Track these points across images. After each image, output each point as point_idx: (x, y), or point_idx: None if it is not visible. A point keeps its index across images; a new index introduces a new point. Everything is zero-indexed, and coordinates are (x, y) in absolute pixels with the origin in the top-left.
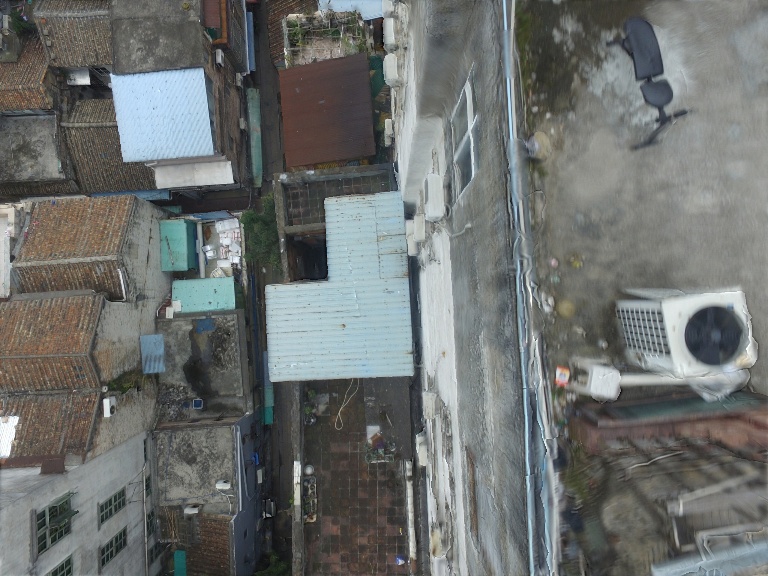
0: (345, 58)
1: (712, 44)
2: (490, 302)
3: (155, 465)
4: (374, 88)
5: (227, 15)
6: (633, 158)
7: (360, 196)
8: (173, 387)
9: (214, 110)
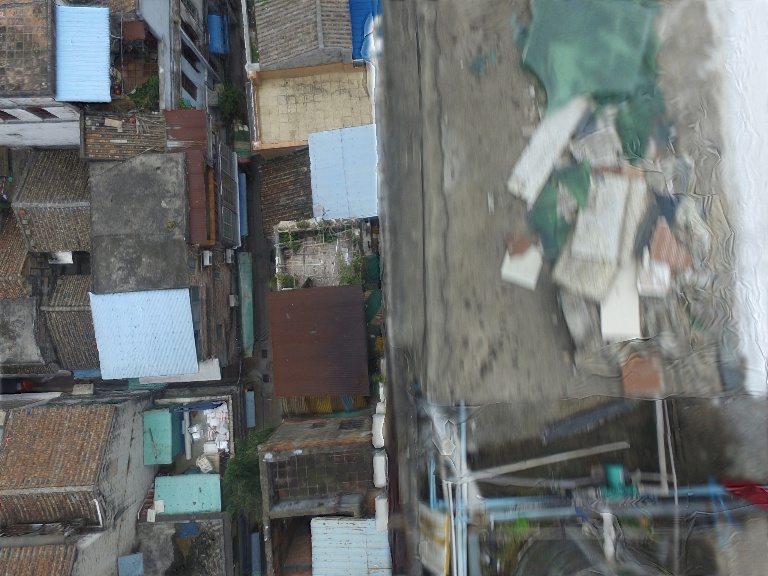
0: (339, 288)
1: None
2: None
3: None
4: (370, 311)
5: (216, 210)
6: None
7: (350, 521)
8: None
9: (200, 316)
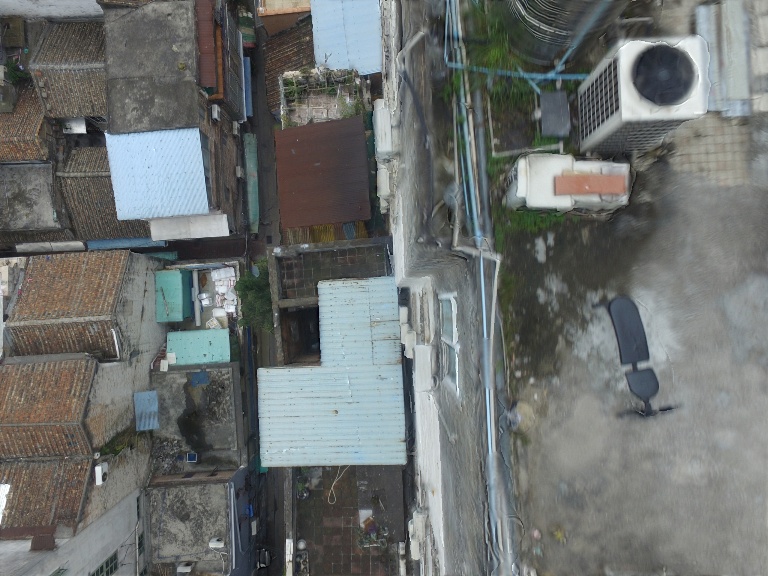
0: (341, 121)
1: (701, 307)
2: (471, 575)
3: (148, 522)
4: (370, 149)
5: (223, 69)
6: (619, 427)
7: (354, 280)
8: (167, 440)
9: (210, 166)
